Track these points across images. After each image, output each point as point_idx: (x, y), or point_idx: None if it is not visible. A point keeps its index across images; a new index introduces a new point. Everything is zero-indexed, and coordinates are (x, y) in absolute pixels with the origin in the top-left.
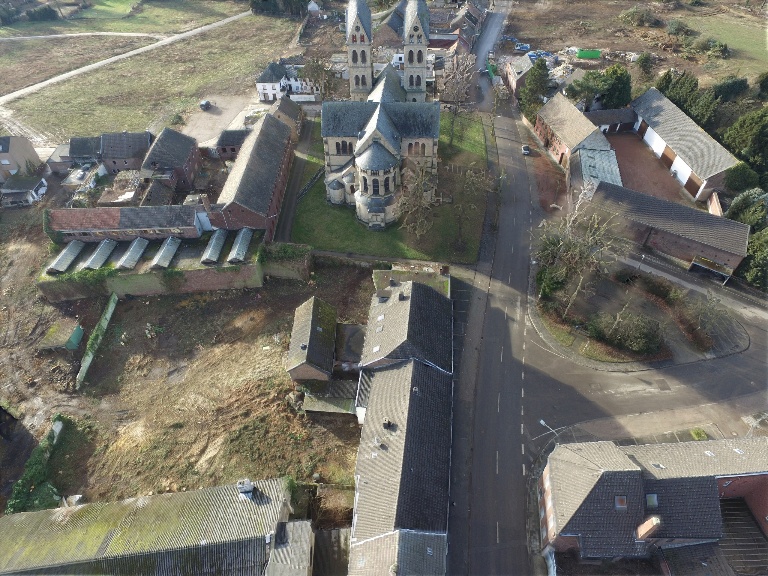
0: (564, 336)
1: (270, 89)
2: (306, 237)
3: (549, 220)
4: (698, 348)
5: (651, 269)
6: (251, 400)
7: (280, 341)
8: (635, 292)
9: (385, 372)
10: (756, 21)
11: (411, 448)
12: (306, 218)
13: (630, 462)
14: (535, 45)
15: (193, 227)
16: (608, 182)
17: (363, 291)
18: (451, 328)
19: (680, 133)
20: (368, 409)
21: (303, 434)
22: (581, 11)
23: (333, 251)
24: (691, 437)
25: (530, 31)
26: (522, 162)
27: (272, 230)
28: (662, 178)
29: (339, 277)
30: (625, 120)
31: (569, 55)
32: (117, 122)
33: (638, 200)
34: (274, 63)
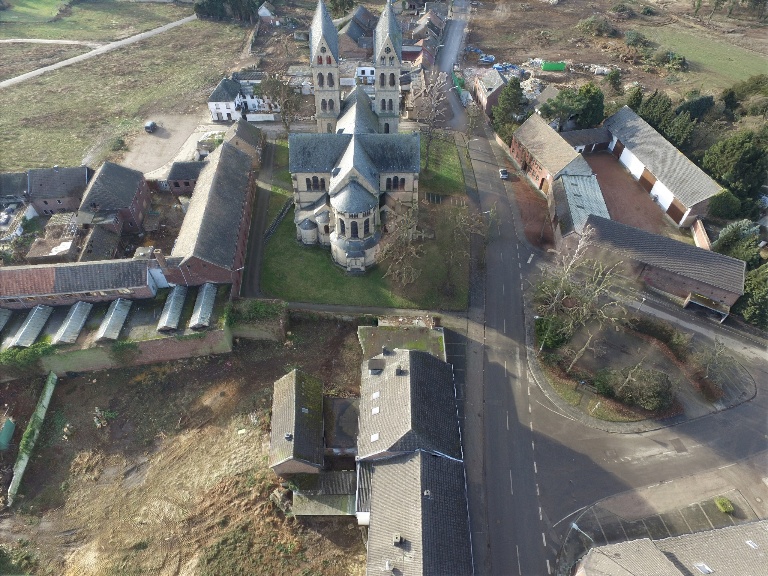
0: (570, 393)
1: (224, 108)
2: (278, 286)
3: (537, 254)
4: (707, 399)
5: (647, 308)
6: (229, 503)
7: (258, 421)
8: (635, 336)
9: (387, 466)
10: (706, 32)
11: (430, 574)
12: (276, 263)
13: (679, 574)
14: (499, 56)
15: (146, 286)
16: (595, 213)
17: (348, 351)
18: (454, 401)
19: (659, 156)
20: (372, 517)
21: (294, 544)
22: (539, 19)
23: (310, 302)
24: (717, 508)
25: (492, 40)
26: (501, 188)
27: (238, 281)
28: (643, 203)
29: (319, 334)
30: (600, 140)
31: (534, 67)
32: (47, 149)
33: (630, 235)
34: (227, 79)
